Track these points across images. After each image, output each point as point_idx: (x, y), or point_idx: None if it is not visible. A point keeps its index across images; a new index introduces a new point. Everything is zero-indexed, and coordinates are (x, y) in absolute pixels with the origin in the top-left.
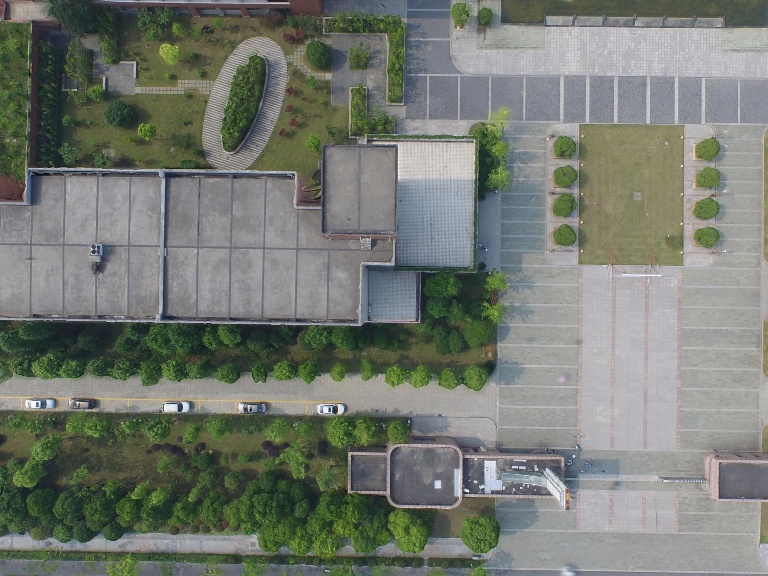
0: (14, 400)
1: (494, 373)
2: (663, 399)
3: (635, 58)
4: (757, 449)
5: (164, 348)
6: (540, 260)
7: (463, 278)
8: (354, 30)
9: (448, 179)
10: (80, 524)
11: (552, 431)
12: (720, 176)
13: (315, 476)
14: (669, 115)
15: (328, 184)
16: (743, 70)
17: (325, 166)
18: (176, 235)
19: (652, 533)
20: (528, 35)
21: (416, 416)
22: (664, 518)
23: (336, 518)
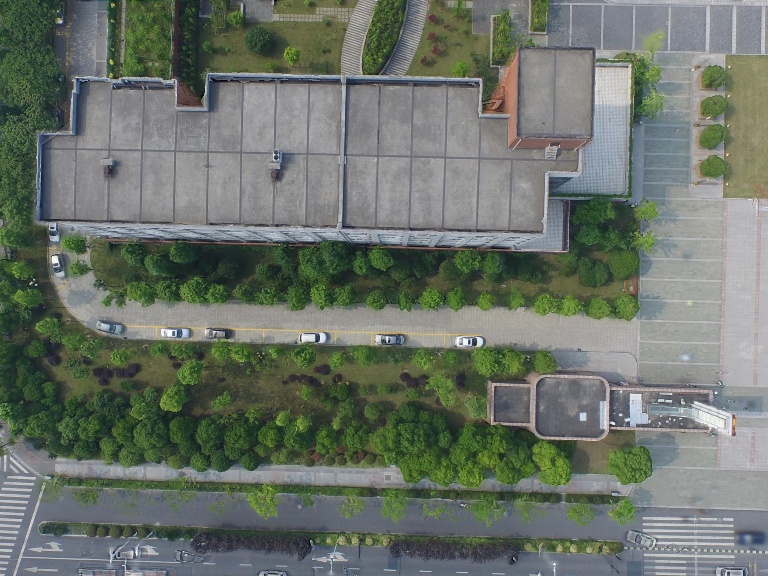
0: (148, 329)
1: None
2: None
3: None
4: None
5: (315, 271)
6: (684, 193)
7: None
8: None
9: (601, 104)
10: (219, 453)
11: (694, 367)
12: None
13: (452, 409)
14: None
15: (522, 87)
16: None
17: (520, 69)
18: (356, 143)
19: None
20: None
21: (555, 350)
22: None
23: (482, 448)
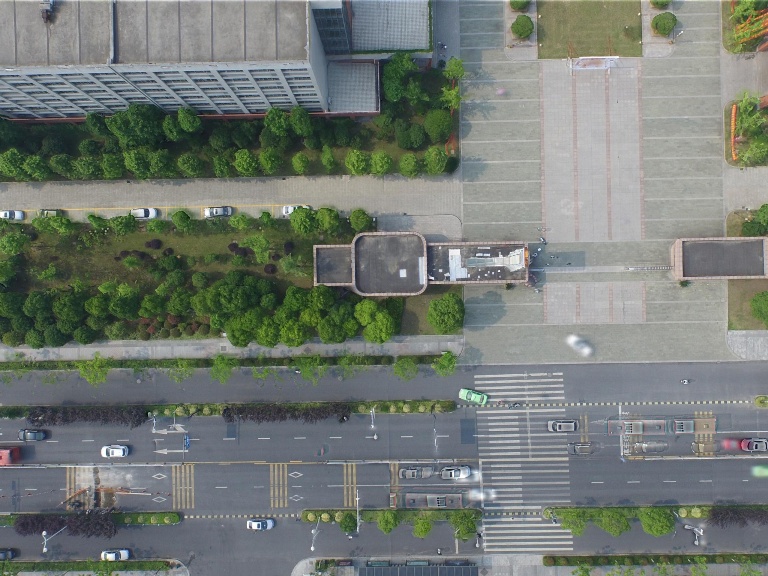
0: None
1: (457, 170)
2: (626, 190)
3: None
4: (722, 236)
5: (125, 135)
6: (500, 56)
7: (423, 76)
8: None
9: None
10: (51, 327)
11: (517, 226)
12: None
13: (283, 278)
14: None
15: None
16: None
17: None
18: None
19: (620, 324)
20: None
21: (381, 215)
22: (631, 308)
23: (302, 306)
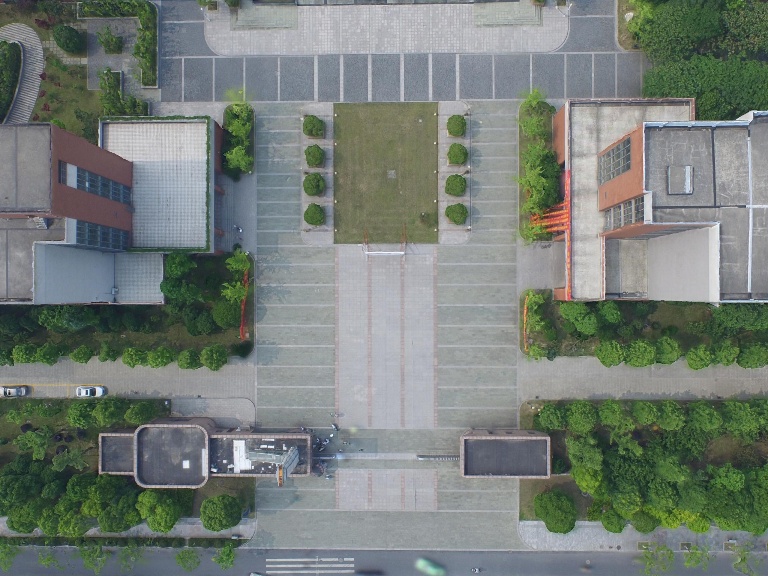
0: None
1: (252, 354)
2: (420, 377)
3: (388, 36)
4: (515, 426)
5: None
6: (296, 240)
7: (219, 259)
8: (105, 14)
9: (184, 160)
10: None
11: (310, 411)
12: (475, 152)
13: None
14: (423, 92)
15: None
16: (497, 45)
17: None
18: None
19: (411, 511)
20: (280, 15)
21: (175, 397)
22: (423, 496)
23: (82, 498)
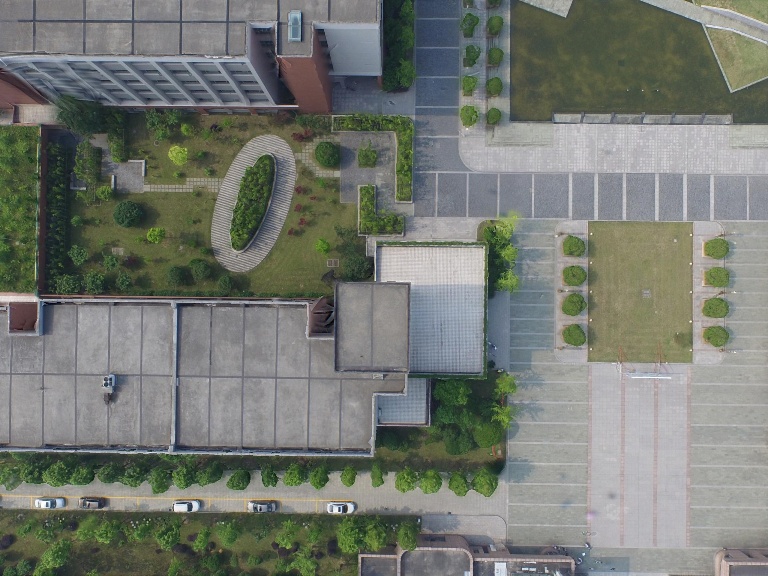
0: (24, 499)
1: (504, 471)
2: (673, 497)
3: (643, 155)
4: (767, 546)
5: None
6: (549, 358)
7: None
8: (363, 129)
9: (458, 284)
10: None
11: (562, 529)
12: (729, 273)
13: (325, 575)
14: (678, 212)
15: (341, 321)
16: (752, 167)
17: (338, 303)
18: (188, 364)
19: None
20: (536, 132)
21: (426, 514)
22: None
23: None
